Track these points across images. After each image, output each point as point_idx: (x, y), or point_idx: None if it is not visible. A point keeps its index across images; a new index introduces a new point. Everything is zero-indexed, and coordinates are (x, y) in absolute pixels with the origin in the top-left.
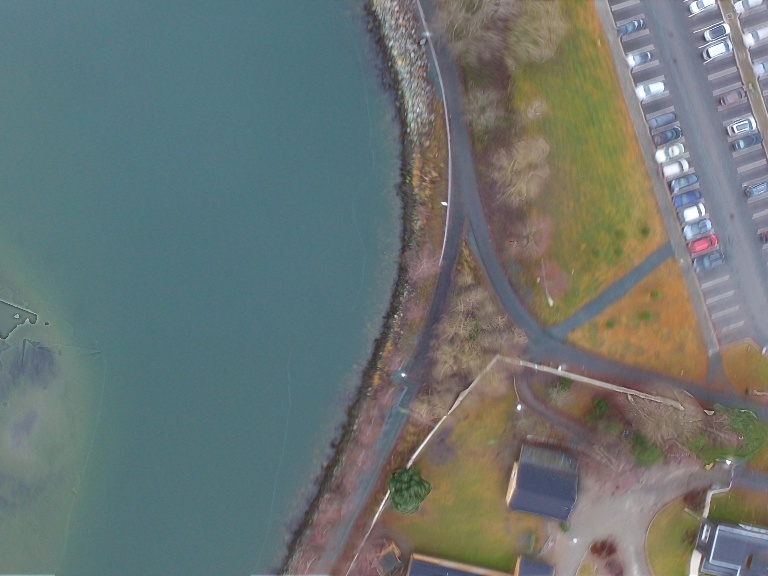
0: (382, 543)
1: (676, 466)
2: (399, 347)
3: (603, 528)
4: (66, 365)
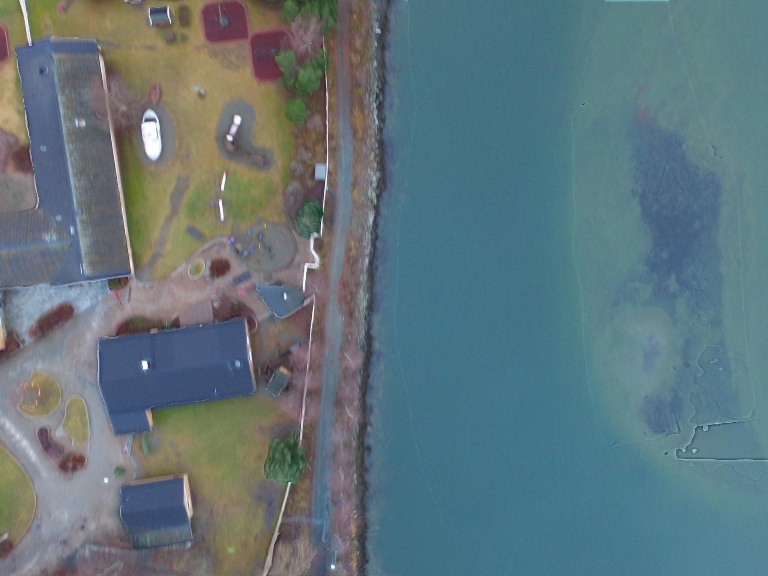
0: (290, 392)
1: (34, 572)
2: (345, 571)
3: (82, 483)
4: (636, 424)
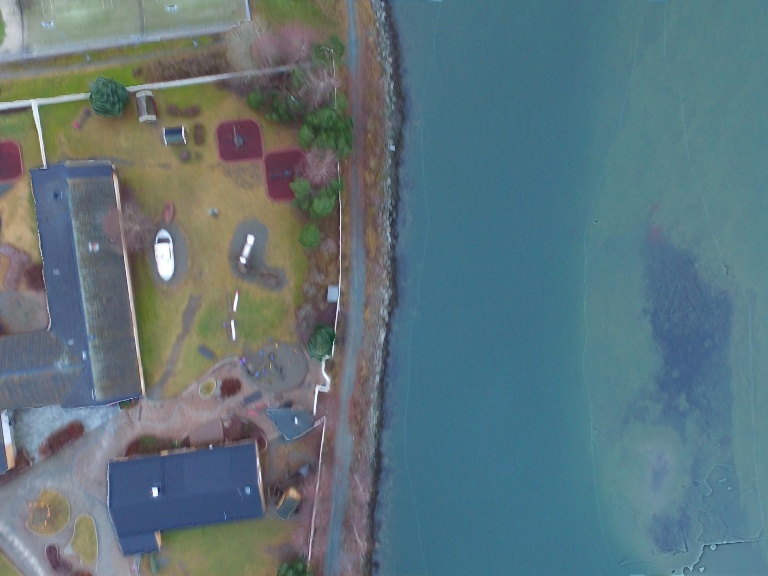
0: None
1: None
2: None
3: None
4: (644, 543)
